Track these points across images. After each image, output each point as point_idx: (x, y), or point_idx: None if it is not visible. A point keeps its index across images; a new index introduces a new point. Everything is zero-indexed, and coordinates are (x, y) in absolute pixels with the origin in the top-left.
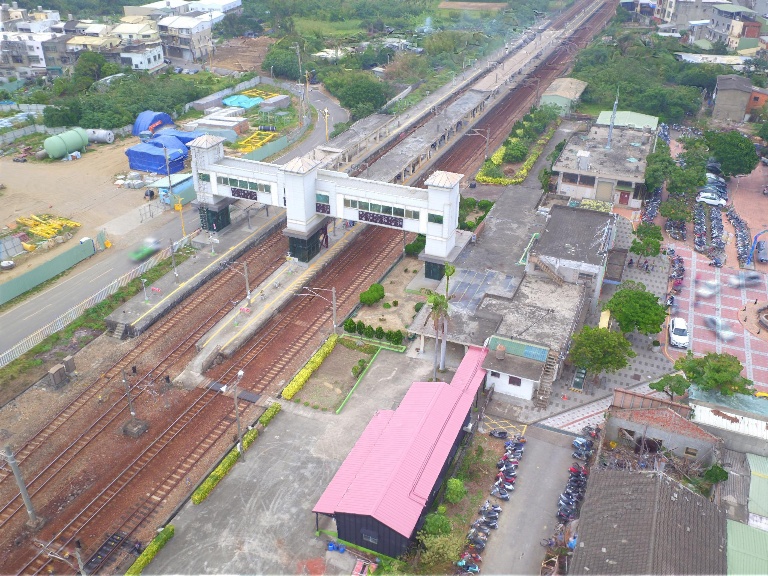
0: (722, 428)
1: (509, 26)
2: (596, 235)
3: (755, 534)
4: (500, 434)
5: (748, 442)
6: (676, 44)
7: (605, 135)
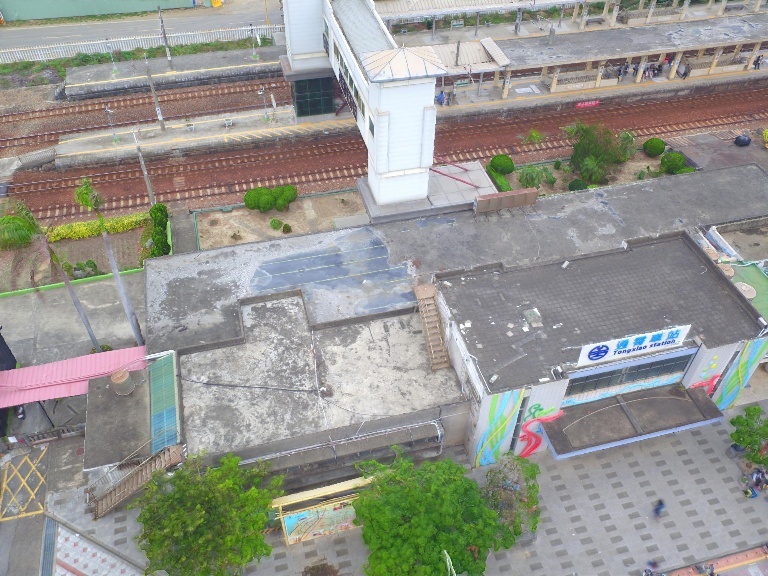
0: None
1: None
2: None
3: None
4: None
5: None
6: None
7: None
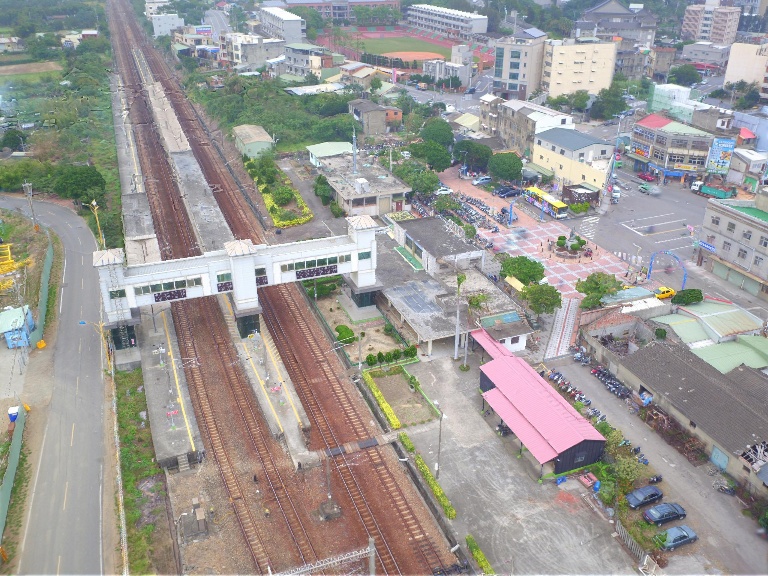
0: (636, 311)
1: (99, 86)
2: (448, 233)
3: (701, 351)
4: (541, 374)
5: (648, 312)
6: (280, 81)
7: (338, 164)
